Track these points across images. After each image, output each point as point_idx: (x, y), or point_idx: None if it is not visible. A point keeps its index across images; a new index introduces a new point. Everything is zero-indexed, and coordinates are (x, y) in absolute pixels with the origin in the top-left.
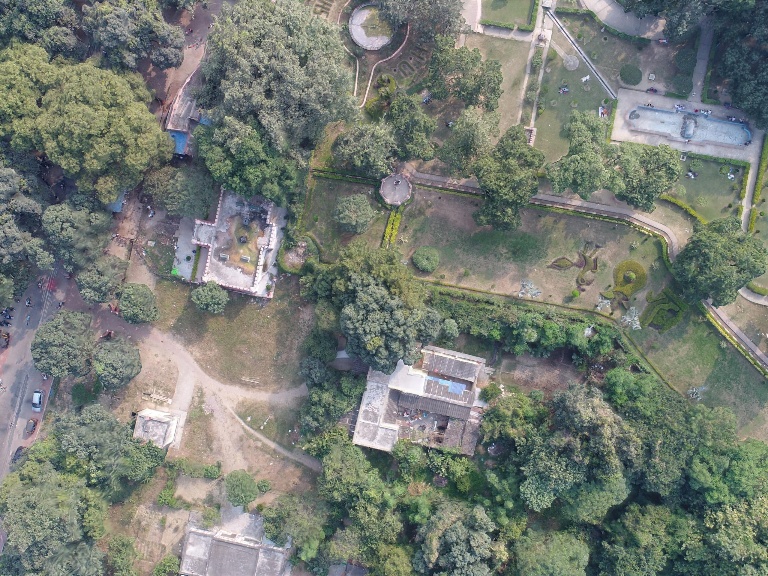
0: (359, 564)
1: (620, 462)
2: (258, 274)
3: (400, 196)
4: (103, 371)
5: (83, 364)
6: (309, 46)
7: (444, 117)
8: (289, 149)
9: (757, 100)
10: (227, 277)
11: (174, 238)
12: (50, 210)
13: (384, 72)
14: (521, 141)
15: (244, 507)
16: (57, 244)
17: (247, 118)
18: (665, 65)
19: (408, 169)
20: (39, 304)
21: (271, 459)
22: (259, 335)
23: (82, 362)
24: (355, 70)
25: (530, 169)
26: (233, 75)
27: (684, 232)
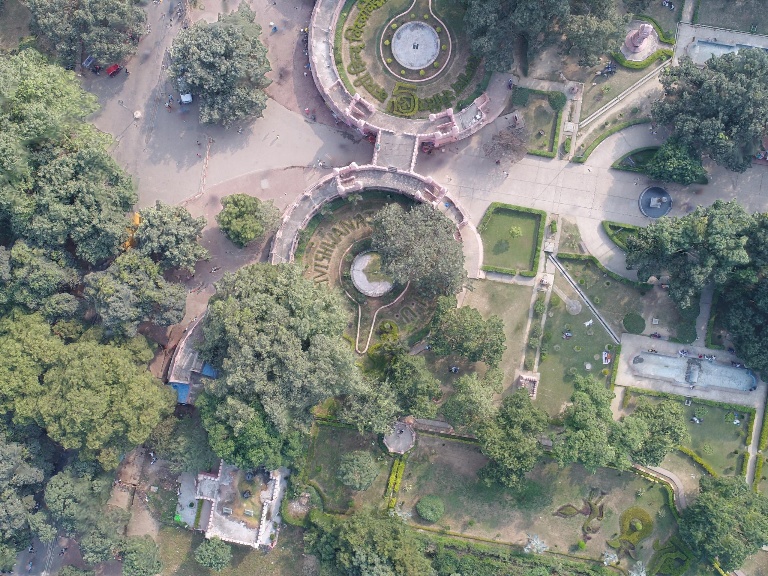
0: None
1: None
2: (262, 528)
3: (404, 444)
4: None
5: None
6: (311, 327)
7: (447, 362)
8: (292, 421)
9: (762, 363)
10: (230, 531)
11: (177, 483)
12: (52, 487)
13: (386, 318)
14: (525, 408)
15: None
16: (59, 518)
17: (250, 397)
18: (668, 309)
19: (411, 415)
20: (41, 550)
21: None
22: None
23: None
24: (357, 316)
25: (534, 441)
26: (235, 361)
27: (690, 478)
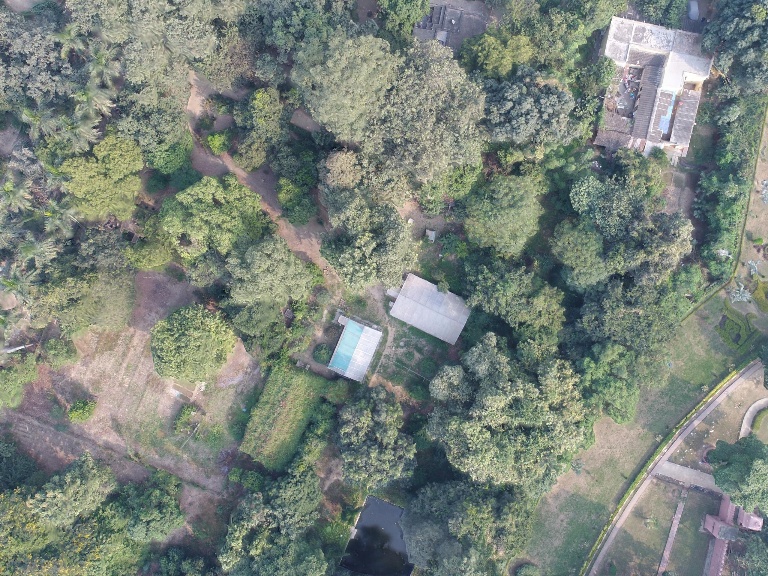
0: None
1: (609, 279)
2: None
3: None
4: None
5: None
6: None
7: None
8: None
9: None
10: None
11: None
12: None
13: None
14: None
15: None
16: None
17: None
18: None
19: None
20: None
21: None
22: None
23: None
24: None
25: None
26: None
27: None
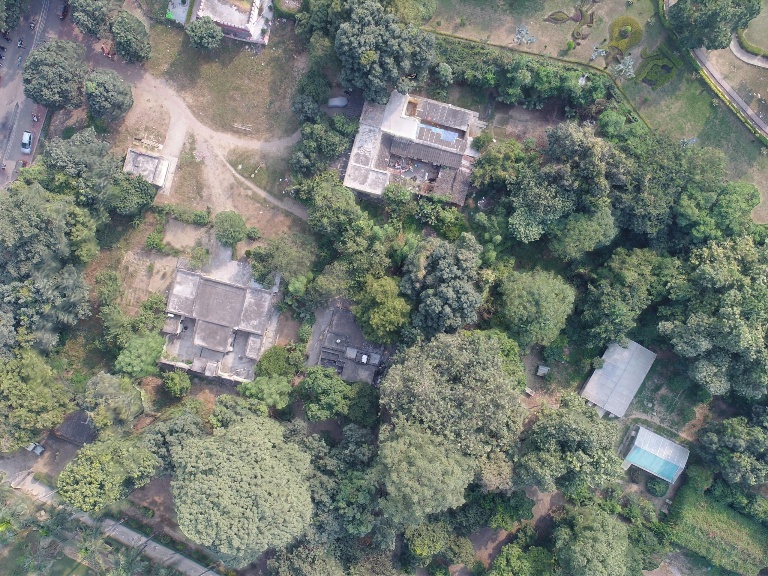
0: (346, 309)
1: (609, 203)
2: (253, 12)
3: None
4: (95, 90)
5: (74, 91)
6: None
7: None
8: None
9: None
10: (222, 15)
11: None
12: None
13: None
14: None
15: (233, 254)
16: None
17: None
18: None
19: None
20: (31, 45)
21: (261, 208)
22: (253, 82)
23: (73, 87)
24: None
25: None
26: None
27: None
